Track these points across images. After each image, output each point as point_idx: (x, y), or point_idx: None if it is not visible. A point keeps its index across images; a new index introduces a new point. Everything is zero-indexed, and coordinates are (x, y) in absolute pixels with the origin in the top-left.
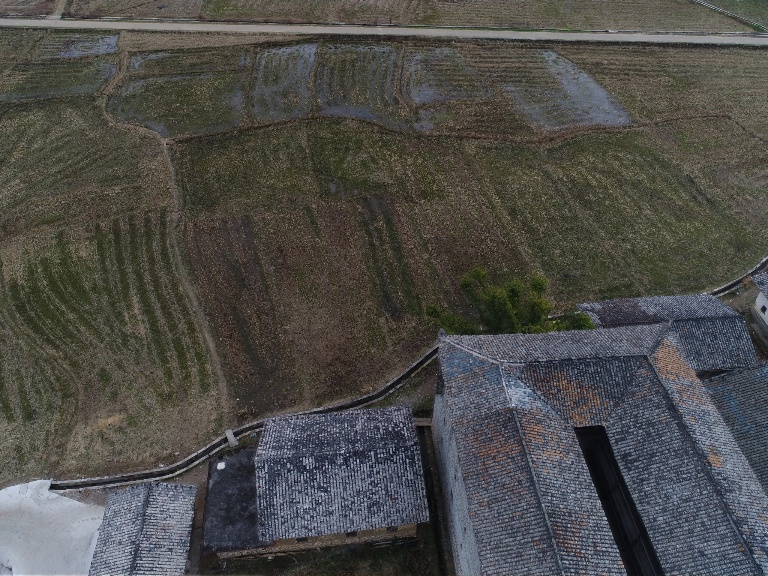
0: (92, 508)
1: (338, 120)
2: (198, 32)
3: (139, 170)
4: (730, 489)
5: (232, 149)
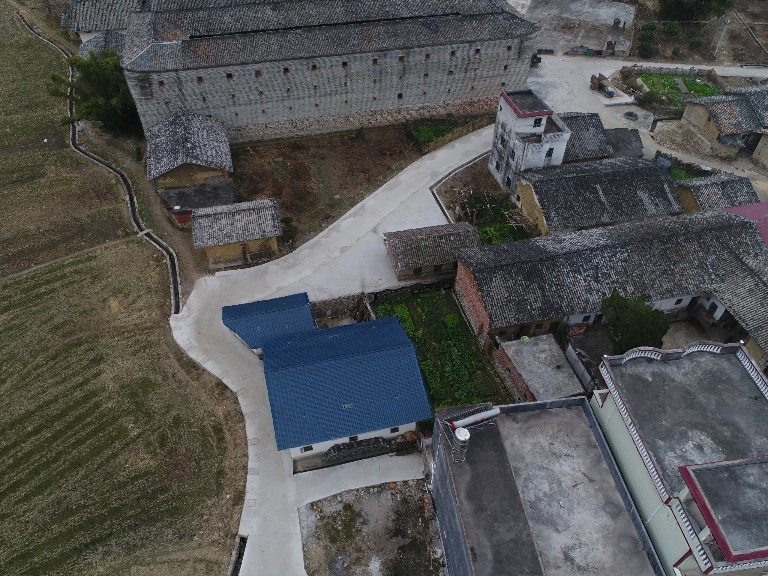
0: (197, 285)
1: None
2: None
3: None
4: None
5: None
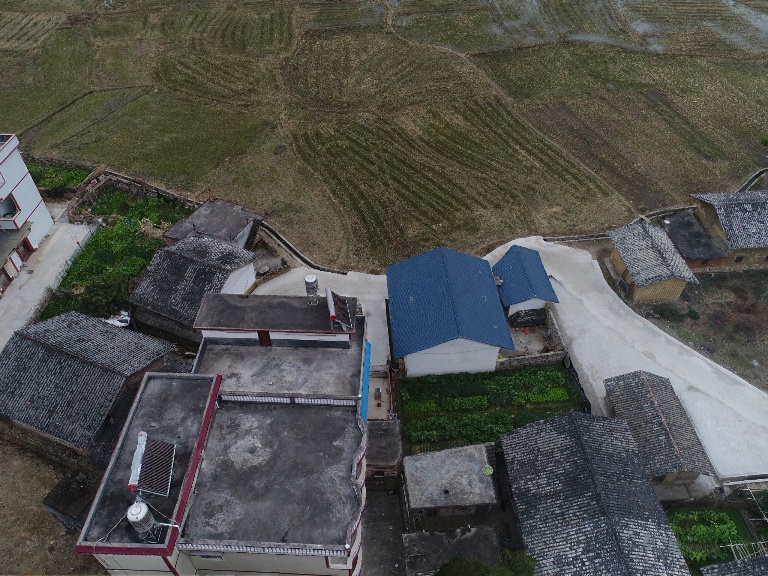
0: (579, 250)
1: (586, 43)
2: None
3: (457, 73)
4: None
5: (516, 61)
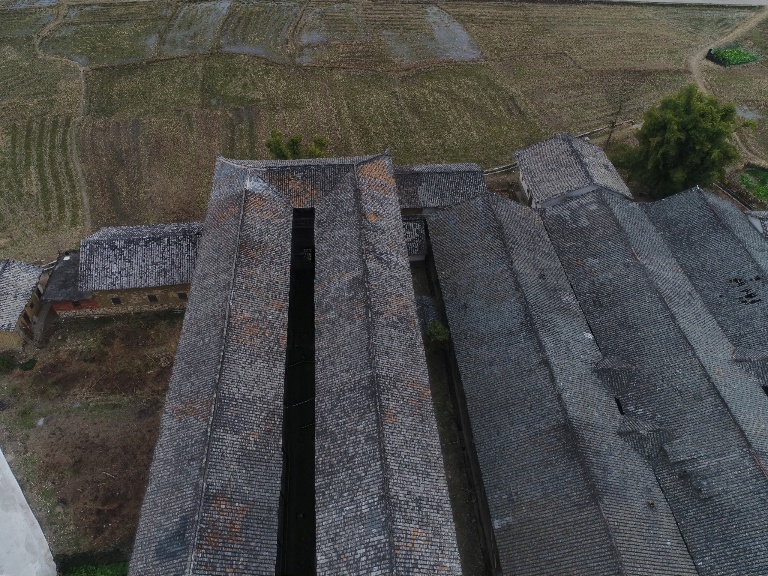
0: None
1: (233, 55)
2: None
3: (56, 88)
4: (373, 230)
5: (138, 75)
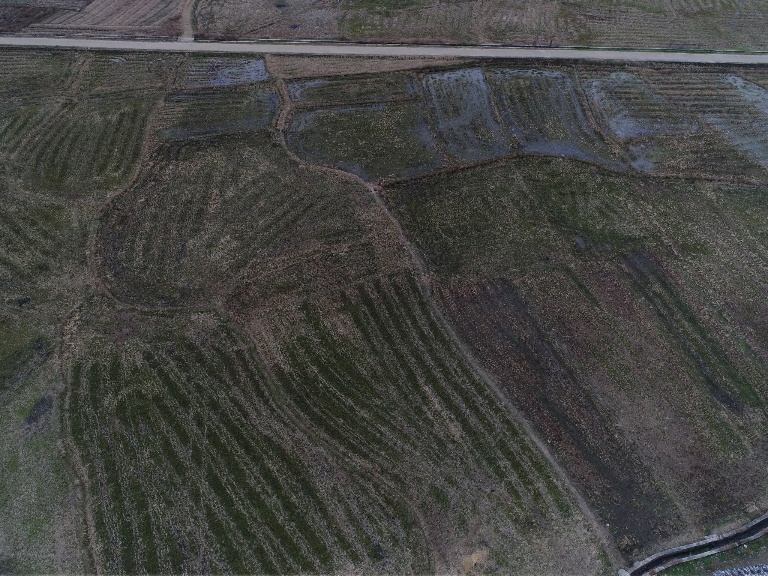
0: None
1: (547, 159)
2: (349, 55)
3: (358, 223)
4: None
5: (448, 195)
